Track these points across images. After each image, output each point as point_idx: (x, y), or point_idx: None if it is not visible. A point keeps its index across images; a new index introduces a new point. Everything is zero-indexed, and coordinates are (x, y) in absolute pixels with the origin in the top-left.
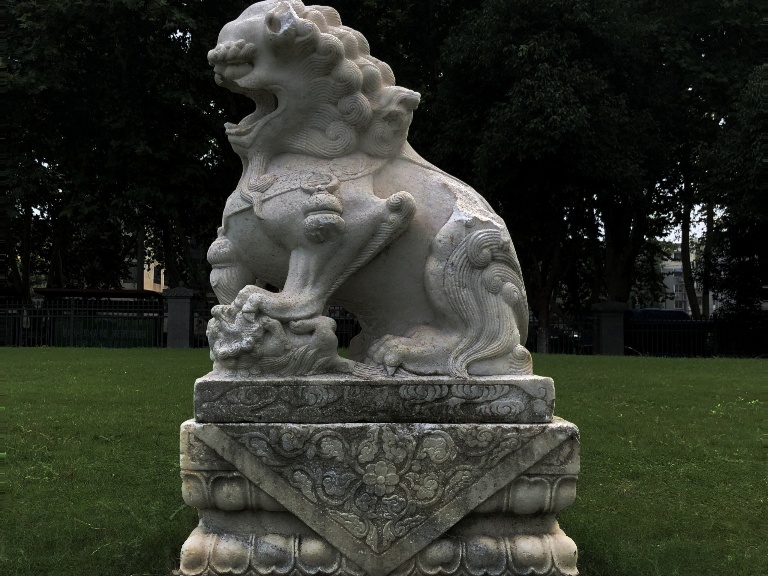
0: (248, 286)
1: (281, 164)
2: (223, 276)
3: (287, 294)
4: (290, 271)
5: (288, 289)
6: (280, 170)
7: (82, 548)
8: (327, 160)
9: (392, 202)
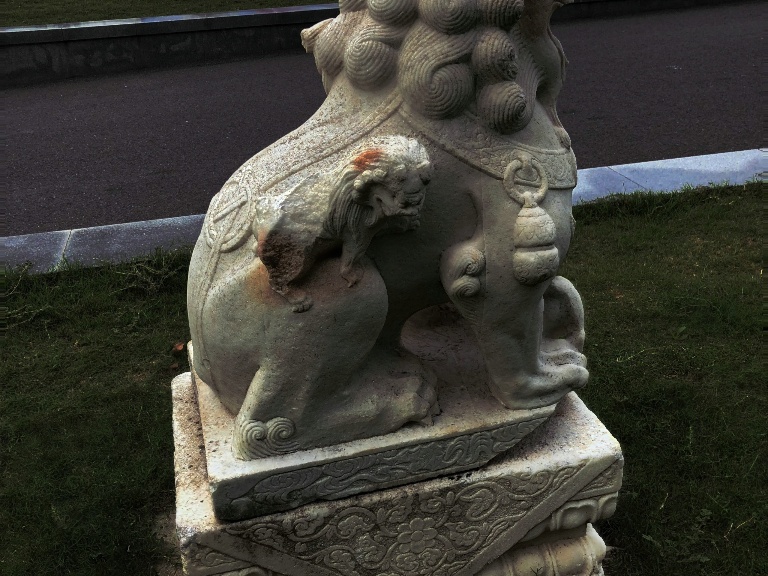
0: None
1: None
2: None
3: None
4: None
5: None
6: None
7: (699, 507)
8: None
9: None
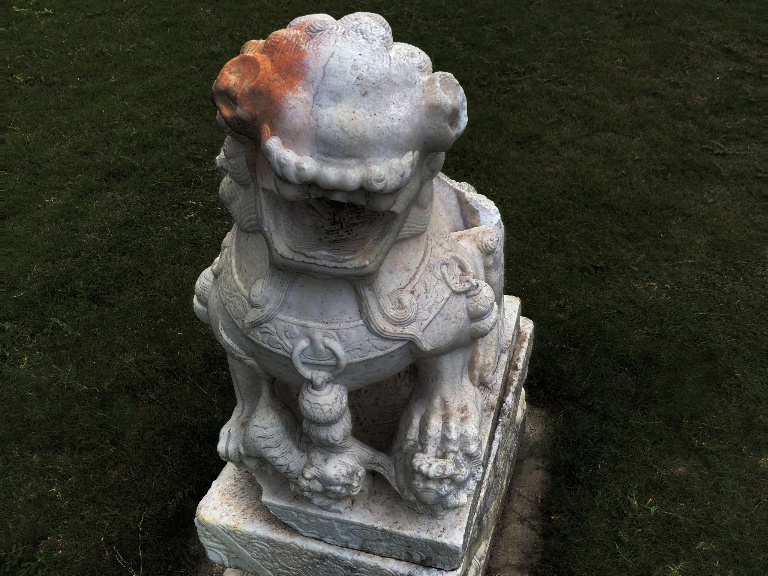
0: (453, 426)
1: (390, 267)
2: (345, 426)
3: (457, 400)
4: (447, 376)
5: (451, 394)
6: (400, 277)
7: None
8: (424, 233)
9: (494, 248)
